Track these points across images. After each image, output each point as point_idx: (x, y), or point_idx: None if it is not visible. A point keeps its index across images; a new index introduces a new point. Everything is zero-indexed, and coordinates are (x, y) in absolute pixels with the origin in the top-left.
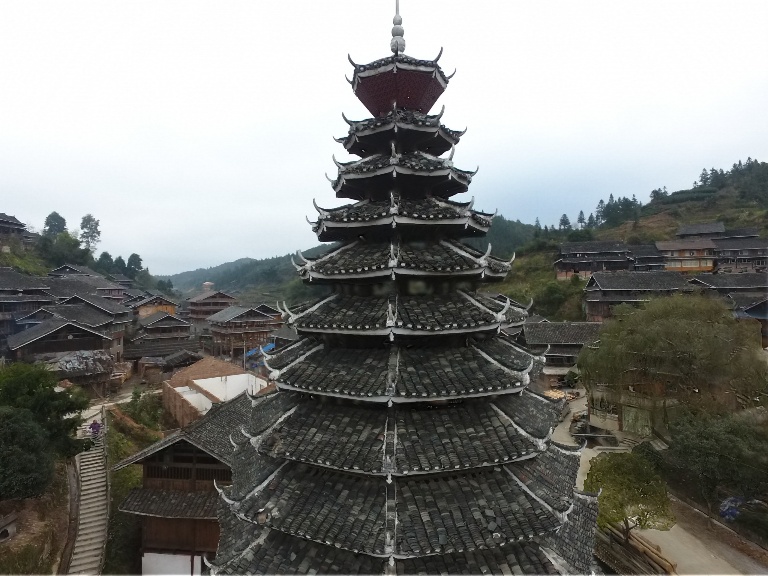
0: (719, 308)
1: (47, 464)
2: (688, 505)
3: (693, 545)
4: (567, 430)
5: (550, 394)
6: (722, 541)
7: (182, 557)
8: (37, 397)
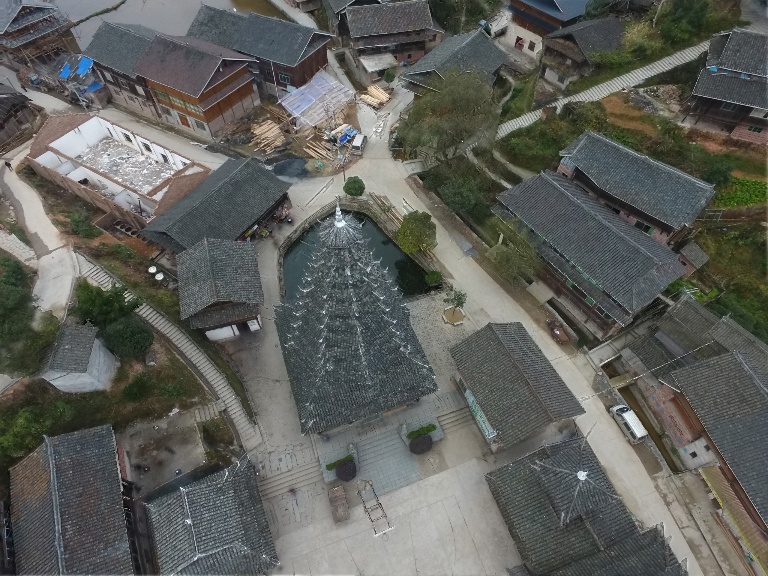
0: (483, 96)
1: (149, 331)
2: (447, 207)
3: (444, 236)
4: (387, 145)
5: (373, 92)
6: (456, 230)
7: (226, 327)
8: (117, 309)
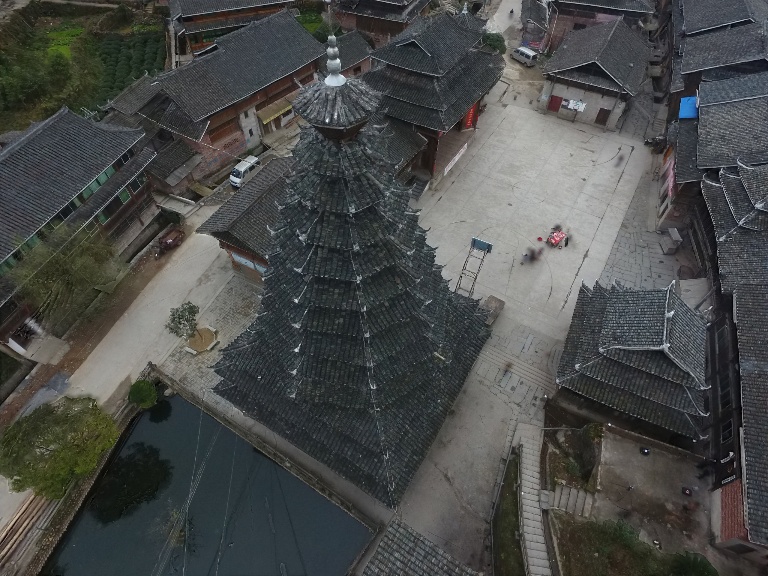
0: None
1: None
2: None
3: None
4: None
5: None
6: (2, 432)
7: None
8: None
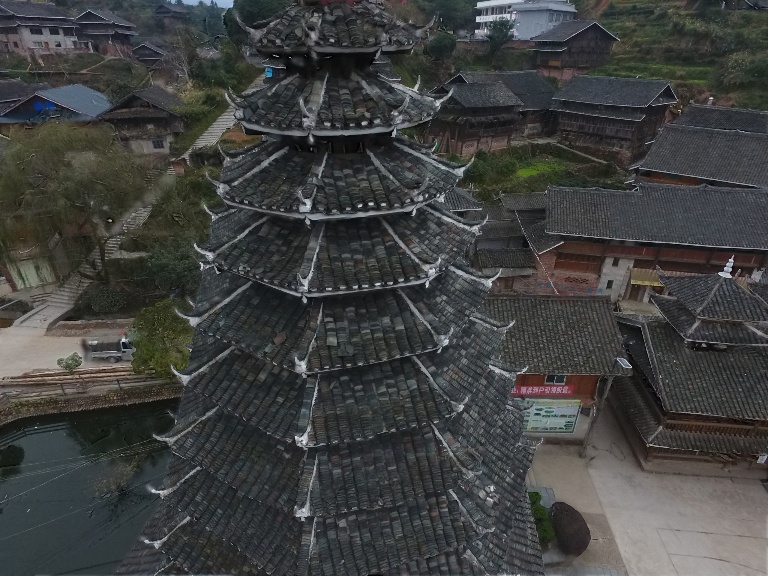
0: (106, 135)
1: None
2: None
3: None
4: None
5: None
6: None
7: None
8: None
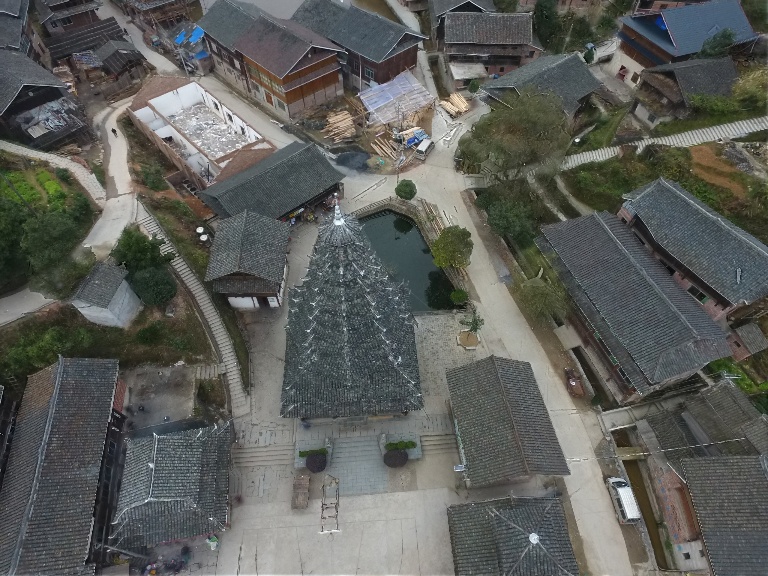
0: (553, 122)
1: (174, 285)
2: None
3: (483, 257)
4: (453, 155)
5: (454, 100)
6: (498, 253)
7: (247, 298)
8: (149, 258)
